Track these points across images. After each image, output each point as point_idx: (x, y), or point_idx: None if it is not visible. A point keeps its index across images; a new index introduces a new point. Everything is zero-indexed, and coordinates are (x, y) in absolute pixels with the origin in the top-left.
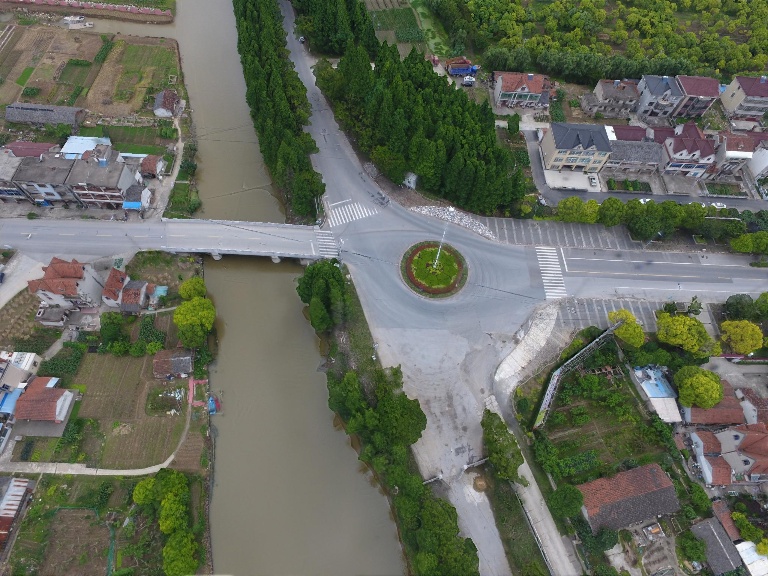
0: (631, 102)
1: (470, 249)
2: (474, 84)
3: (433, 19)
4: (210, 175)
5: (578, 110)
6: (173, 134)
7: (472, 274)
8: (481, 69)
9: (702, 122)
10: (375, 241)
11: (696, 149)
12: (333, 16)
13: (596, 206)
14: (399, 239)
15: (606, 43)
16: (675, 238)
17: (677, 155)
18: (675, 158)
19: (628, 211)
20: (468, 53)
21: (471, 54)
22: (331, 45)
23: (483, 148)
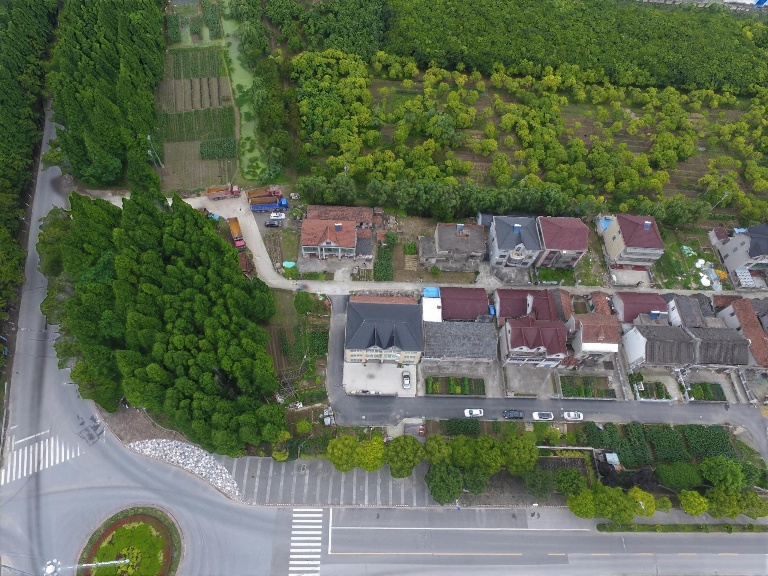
0: (478, 253)
1: (195, 518)
2: (283, 223)
3: (258, 122)
4: None
5: (414, 259)
6: None
7: (185, 568)
8: (299, 198)
9: (573, 275)
10: (58, 509)
11: (539, 344)
12: (82, 145)
13: (379, 451)
14: (95, 504)
15: (472, 153)
16: (499, 482)
17: (516, 349)
18: (514, 351)
19: (424, 457)
20: (289, 173)
21: (293, 174)
22: None
23: (226, 364)
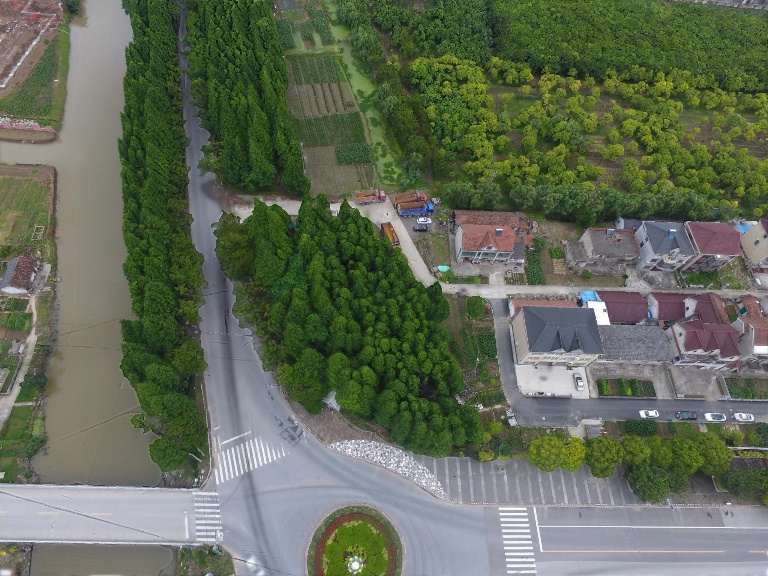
0: (628, 257)
1: (408, 517)
2: (430, 227)
3: (385, 127)
4: (73, 378)
5: (561, 263)
6: (25, 322)
7: (408, 565)
8: (440, 203)
9: (718, 278)
10: (276, 508)
11: (715, 347)
12: (245, 151)
13: (582, 451)
14: (310, 503)
15: (597, 158)
16: None
17: (689, 352)
18: (687, 354)
19: (625, 457)
20: (425, 178)
21: (429, 179)
22: (244, 185)
23: (428, 367)
